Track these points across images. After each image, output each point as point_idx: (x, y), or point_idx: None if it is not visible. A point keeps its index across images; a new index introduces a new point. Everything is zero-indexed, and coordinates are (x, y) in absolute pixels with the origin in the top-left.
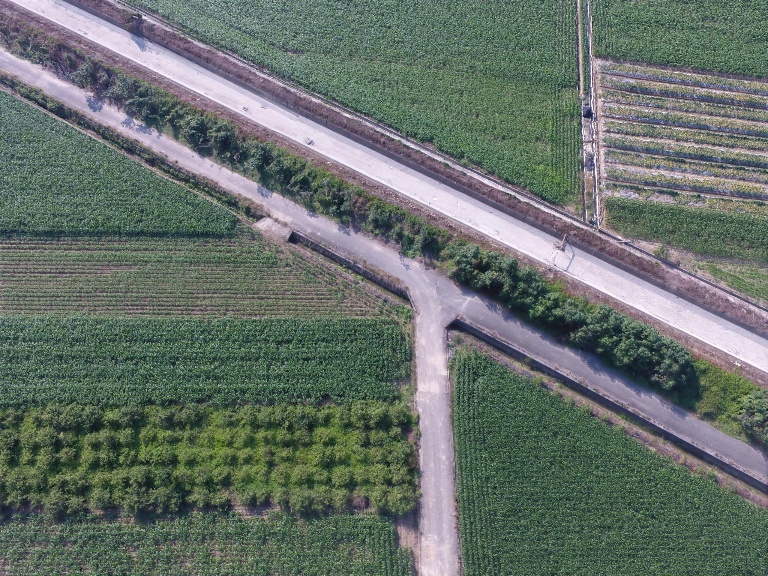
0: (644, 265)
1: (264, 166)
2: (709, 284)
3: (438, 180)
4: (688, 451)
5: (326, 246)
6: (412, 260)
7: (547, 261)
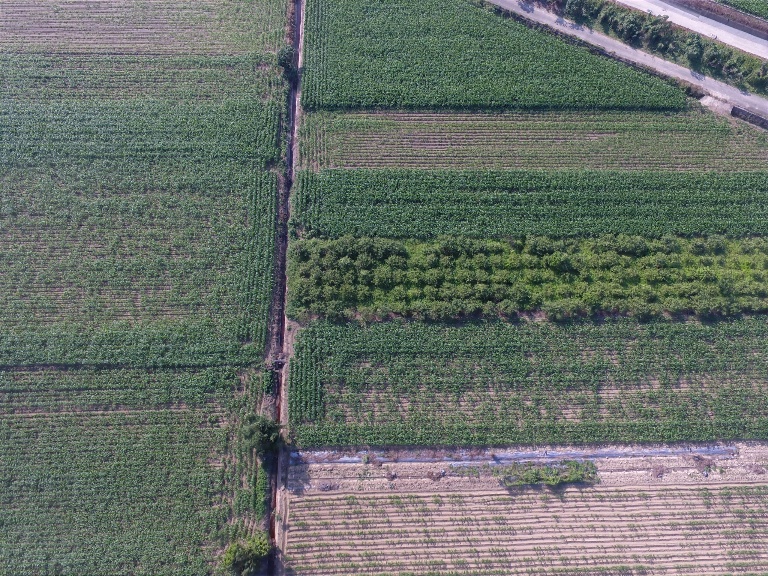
0: None
1: (698, 53)
2: None
3: None
4: None
5: (767, 117)
6: None
7: None
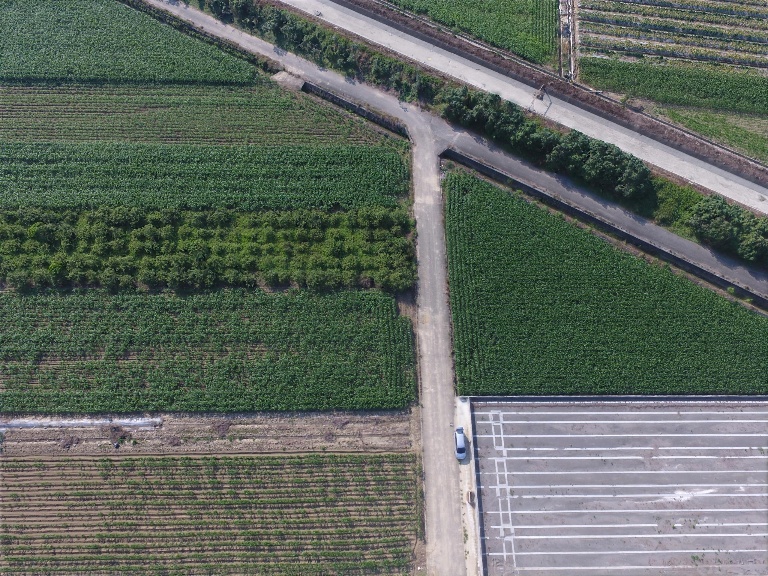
0: (612, 108)
1: (279, 28)
2: (669, 125)
3: (432, 43)
4: (647, 252)
5: (334, 93)
6: (409, 104)
7: (527, 107)
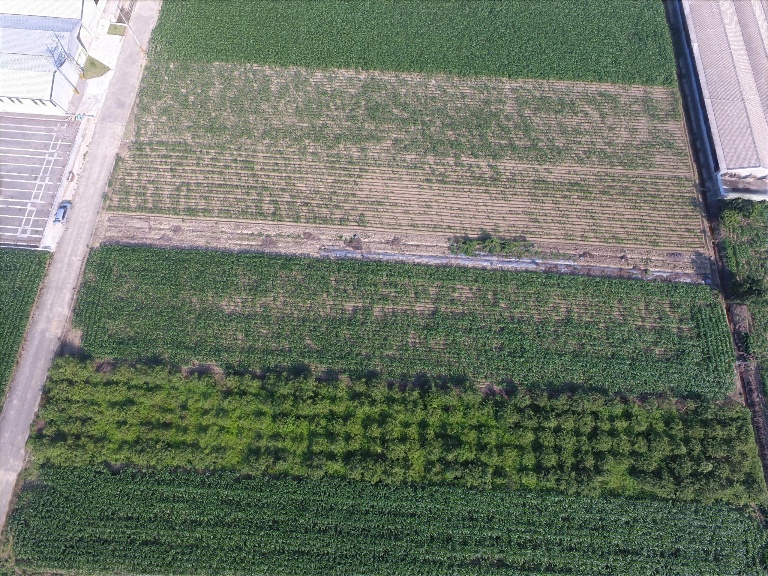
0: None
1: None
2: None
3: None
4: None
5: None
6: None
7: None
